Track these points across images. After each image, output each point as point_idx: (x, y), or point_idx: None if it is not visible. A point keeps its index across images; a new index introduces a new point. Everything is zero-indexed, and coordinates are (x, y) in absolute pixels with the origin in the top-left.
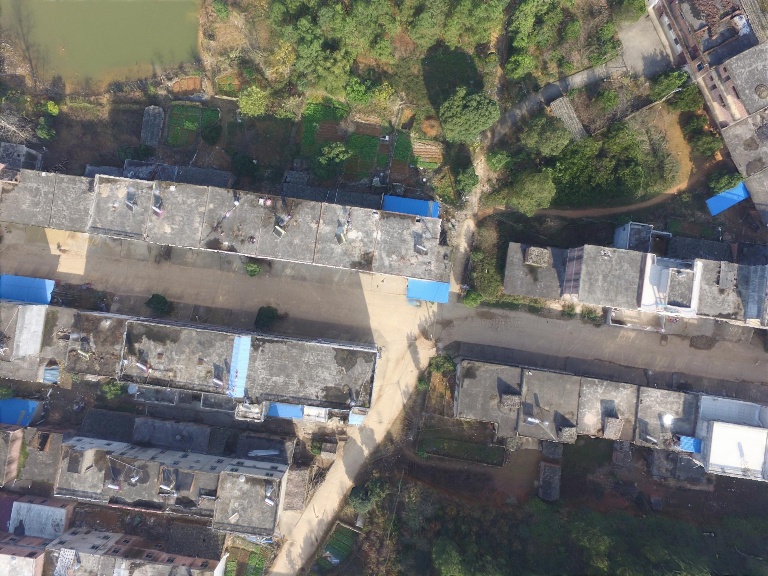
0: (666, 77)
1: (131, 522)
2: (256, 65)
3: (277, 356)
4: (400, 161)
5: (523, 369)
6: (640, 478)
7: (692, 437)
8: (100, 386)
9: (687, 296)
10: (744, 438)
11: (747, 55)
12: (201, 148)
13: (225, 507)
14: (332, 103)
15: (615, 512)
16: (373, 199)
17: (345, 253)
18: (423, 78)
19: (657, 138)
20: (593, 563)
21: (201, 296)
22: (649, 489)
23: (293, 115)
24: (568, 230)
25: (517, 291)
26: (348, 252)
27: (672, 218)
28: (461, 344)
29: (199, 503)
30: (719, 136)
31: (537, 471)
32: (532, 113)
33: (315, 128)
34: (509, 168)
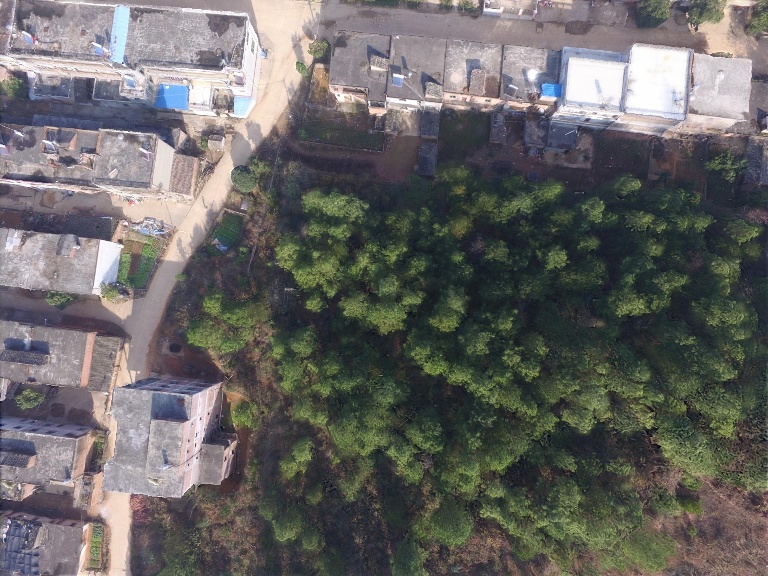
0: None
1: (34, 222)
2: None
3: (154, 25)
4: None
5: None
6: (518, 158)
7: (553, 84)
8: (4, 92)
9: None
10: (601, 75)
11: None
12: None
13: (105, 164)
14: None
15: (486, 176)
16: None
17: None
18: None
19: None
20: (451, 192)
21: None
22: (526, 168)
23: None
24: None
25: None
26: None
27: None
28: None
29: (80, 160)
30: None
31: (417, 155)
32: None
33: None
34: None
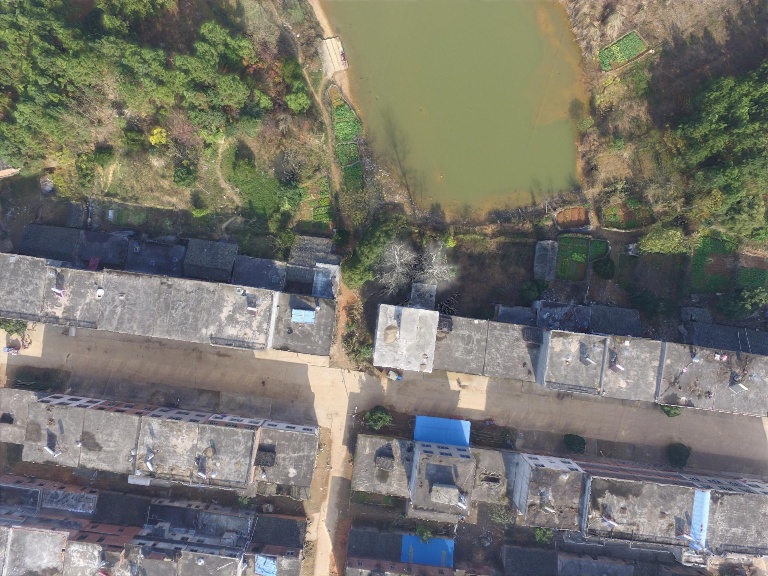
0: None
1: None
2: (646, 198)
3: (735, 508)
4: None
5: None
6: None
7: None
8: (518, 525)
9: None
10: None
11: None
12: (591, 280)
13: None
14: (720, 236)
15: None
16: None
17: None
18: None
19: None
20: None
21: (603, 431)
22: None
23: (690, 251)
24: None
25: None
26: None
27: None
28: None
29: None
30: None
31: None
32: None
33: (707, 262)
34: None
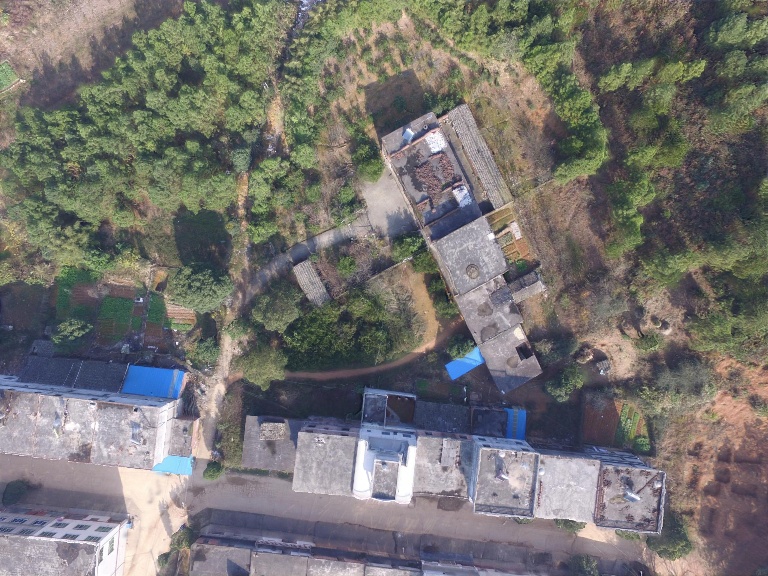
0: (400, 243)
1: None
2: (9, 229)
3: None
4: (154, 324)
5: (251, 551)
6: None
7: None
8: None
9: (392, 487)
10: None
11: (458, 234)
12: None
13: None
14: (86, 265)
15: None
16: (117, 371)
17: (63, 445)
18: (175, 239)
19: (404, 297)
20: None
21: None
22: None
23: (43, 282)
24: (317, 392)
25: (255, 464)
26: (66, 444)
27: (419, 379)
28: (212, 511)
29: None
30: (453, 302)
31: None
32: (281, 273)
33: (68, 293)
34: (256, 332)
